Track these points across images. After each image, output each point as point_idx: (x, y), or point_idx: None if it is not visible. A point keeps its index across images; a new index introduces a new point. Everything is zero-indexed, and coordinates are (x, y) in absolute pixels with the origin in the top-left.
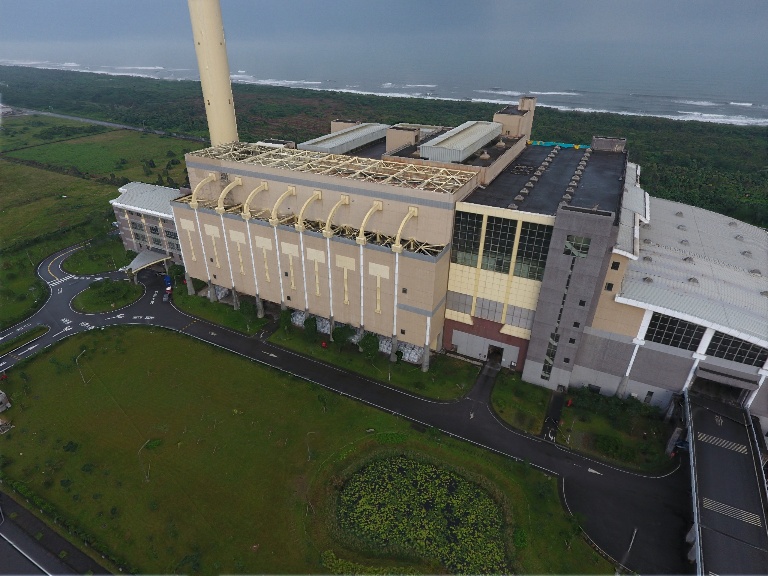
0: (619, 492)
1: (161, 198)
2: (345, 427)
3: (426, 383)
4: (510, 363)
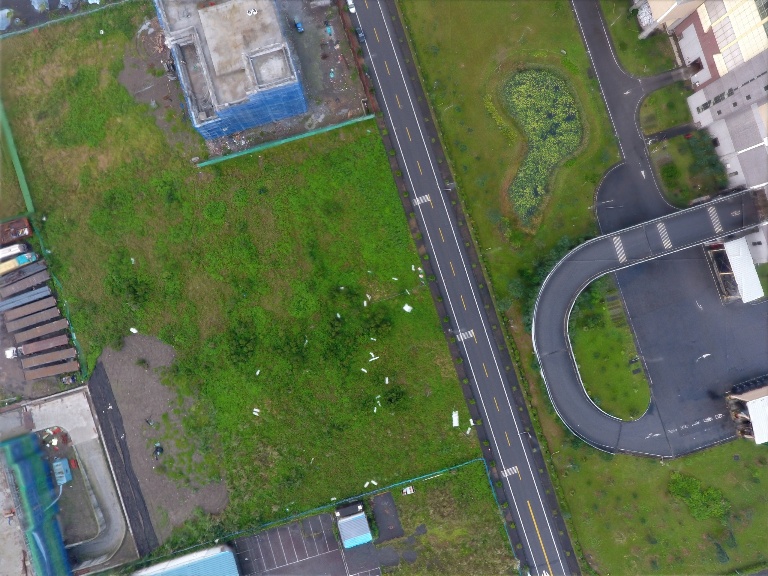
0: (640, 191)
1: None
2: (554, 37)
3: (629, 48)
4: (697, 81)
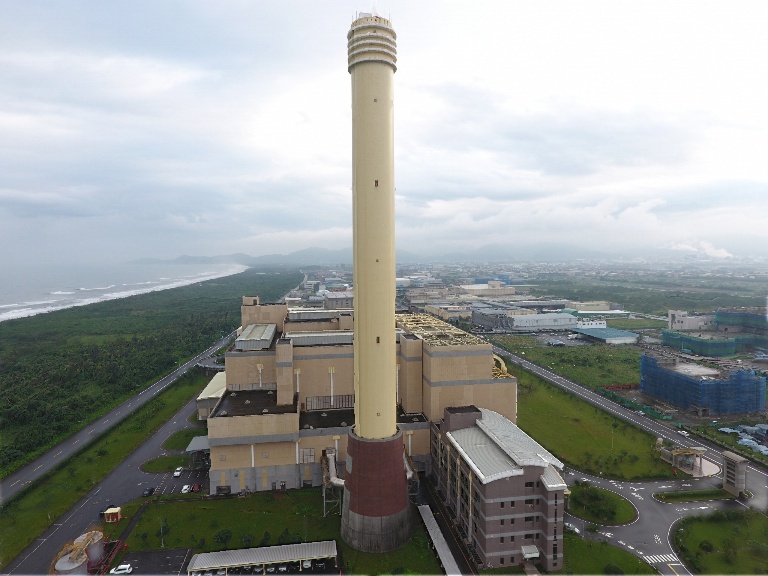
0: None
1: (505, 426)
2: None
3: None
4: None
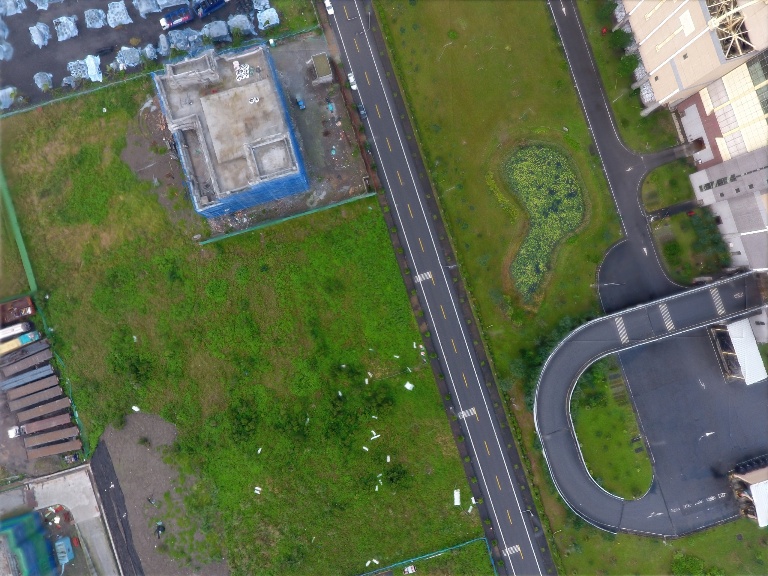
0: (642, 268)
1: None
2: (555, 114)
3: (631, 124)
4: (699, 159)
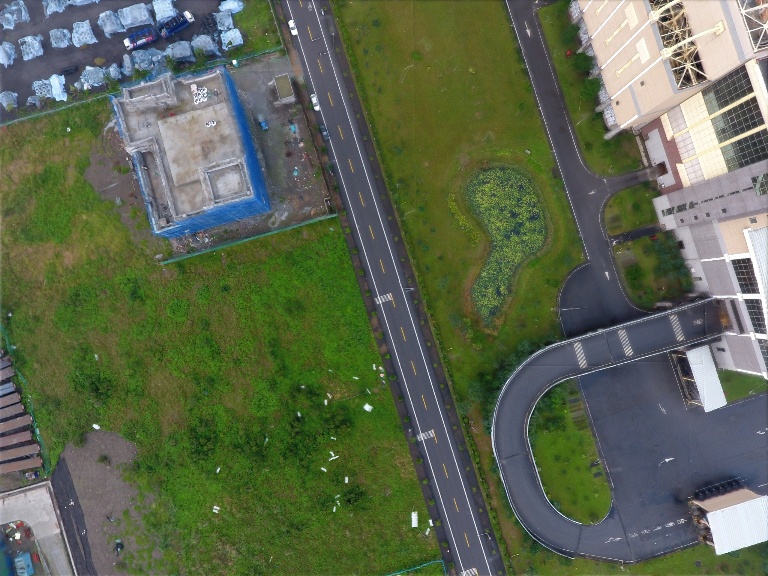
0: (603, 292)
1: None
2: (518, 136)
3: (595, 148)
4: (662, 183)
